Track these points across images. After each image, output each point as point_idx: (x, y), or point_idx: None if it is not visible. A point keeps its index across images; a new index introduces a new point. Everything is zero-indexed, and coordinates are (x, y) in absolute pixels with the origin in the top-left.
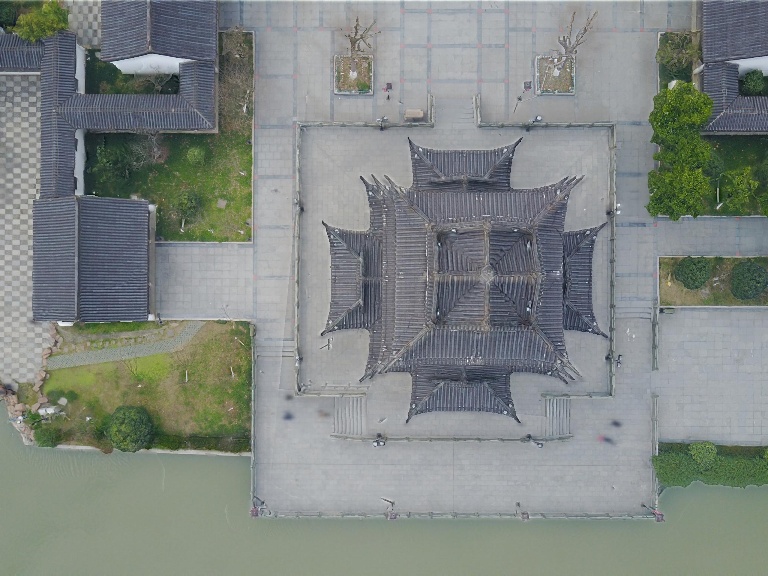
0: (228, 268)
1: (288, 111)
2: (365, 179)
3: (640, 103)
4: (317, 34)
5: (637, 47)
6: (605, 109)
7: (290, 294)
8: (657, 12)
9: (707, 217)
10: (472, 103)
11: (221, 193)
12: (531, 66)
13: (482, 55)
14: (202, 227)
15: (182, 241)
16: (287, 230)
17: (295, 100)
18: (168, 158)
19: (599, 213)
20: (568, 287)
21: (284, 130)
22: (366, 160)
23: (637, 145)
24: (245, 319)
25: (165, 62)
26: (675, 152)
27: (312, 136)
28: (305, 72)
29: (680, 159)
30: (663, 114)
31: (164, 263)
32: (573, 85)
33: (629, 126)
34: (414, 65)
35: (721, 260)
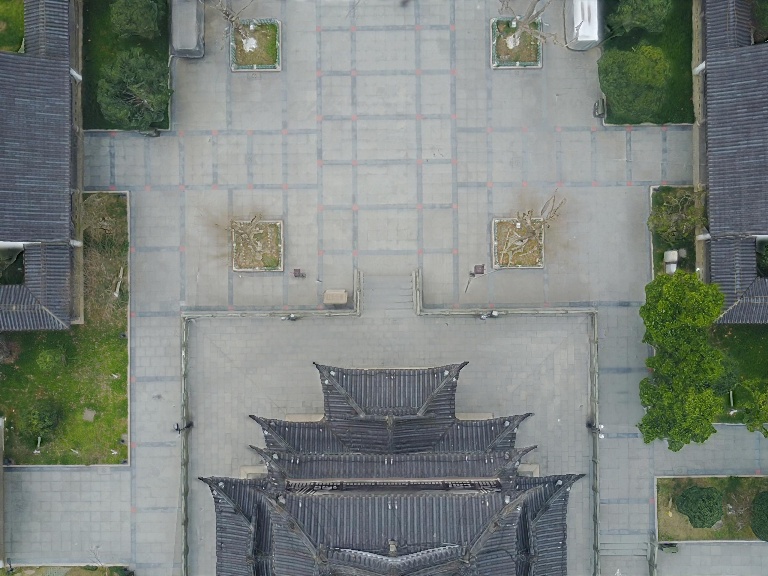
0: (98, 498)
1: (174, 293)
2: (272, 384)
3: (628, 277)
4: (210, 194)
5: (623, 205)
6: (583, 286)
7: (179, 531)
8: (648, 160)
9: (718, 425)
10: (411, 281)
11: (88, 401)
12: (487, 232)
13: (423, 218)
14: (64, 446)
15: (38, 464)
16: (174, 448)
17: (183, 279)
18: (19, 357)
19: (577, 425)
20: (532, 566)
21: (169, 318)
22: (273, 359)
23: (625, 332)
24: (121, 564)
25: (4, 244)
26: (675, 360)
27: (203, 329)
28: (195, 243)
29: (682, 374)
30: (658, 312)
31: (15, 492)
32: (541, 256)
33: (614, 308)
34: (336, 232)
35: (737, 481)
